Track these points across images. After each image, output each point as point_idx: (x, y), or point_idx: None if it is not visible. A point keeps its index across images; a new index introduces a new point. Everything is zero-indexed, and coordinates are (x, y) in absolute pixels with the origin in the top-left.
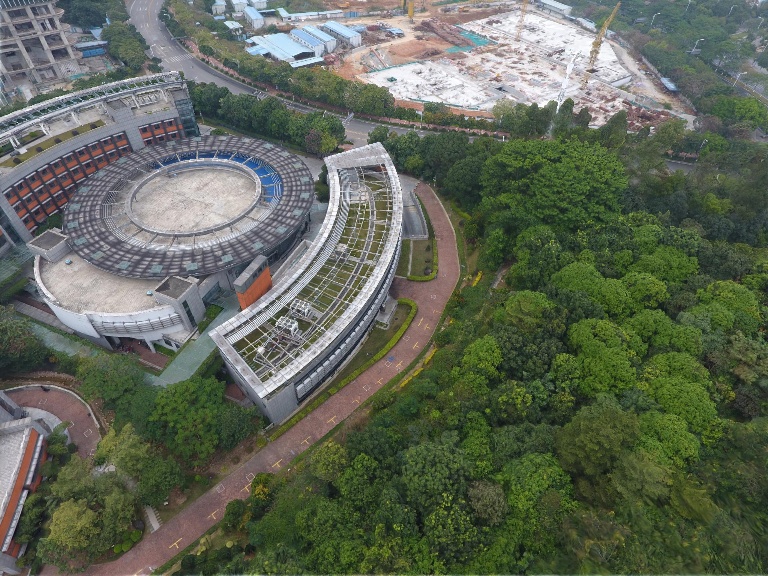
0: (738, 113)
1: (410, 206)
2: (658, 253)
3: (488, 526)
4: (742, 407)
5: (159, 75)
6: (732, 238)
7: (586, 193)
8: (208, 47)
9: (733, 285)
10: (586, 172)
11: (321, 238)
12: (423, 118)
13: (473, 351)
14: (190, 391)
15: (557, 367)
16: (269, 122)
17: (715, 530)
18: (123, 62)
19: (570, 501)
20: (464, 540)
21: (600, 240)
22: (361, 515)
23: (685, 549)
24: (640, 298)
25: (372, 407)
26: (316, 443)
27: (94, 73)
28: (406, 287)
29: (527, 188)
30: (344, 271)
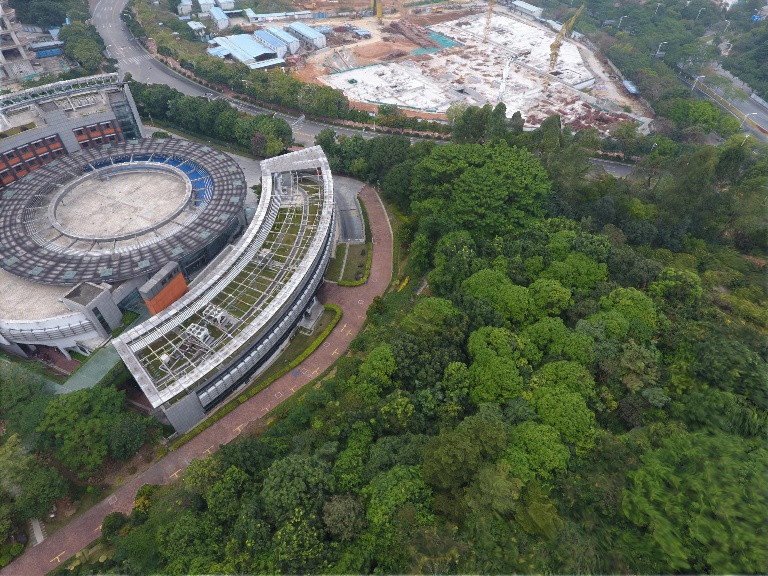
0: (692, 116)
1: (352, 210)
2: (569, 259)
3: (337, 542)
4: (627, 416)
5: (97, 77)
6: (658, 243)
7: (505, 198)
8: (166, 48)
9: (632, 292)
10: (507, 177)
11: (243, 243)
12: (376, 120)
13: (368, 360)
14: (82, 401)
15: (448, 376)
16: (216, 124)
17: (556, 545)
18: (79, 63)
19: (427, 515)
20: (307, 557)
21: (514, 246)
22: (225, 529)
23: (521, 565)
24: (543, 305)
25: (276, 416)
26: (215, 453)
27: (44, 74)
28: (335, 292)
29: (450, 193)
30: None
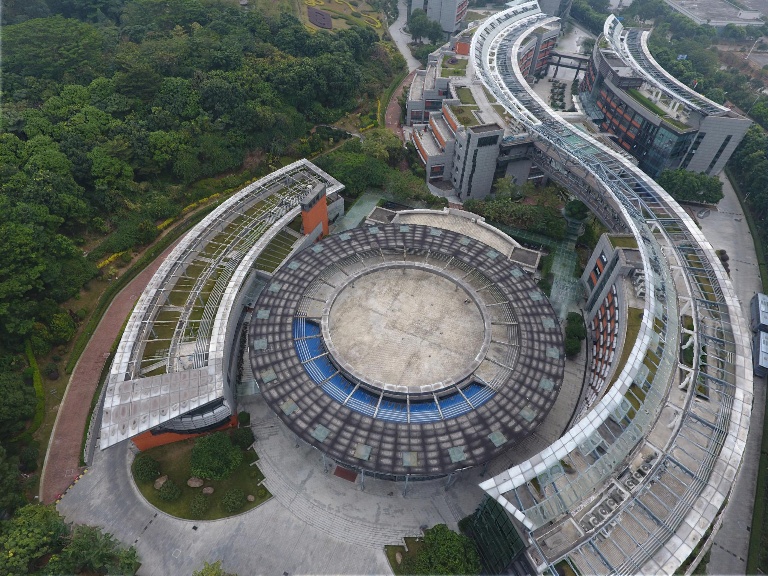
0: None
1: None
2: None
3: None
4: None
5: None
6: None
7: None
8: None
9: None
10: None
11: (252, 254)
12: None
13: None
14: (347, 161)
15: None
16: None
17: None
18: None
19: None
20: None
21: None
22: None
23: None
24: None
25: None
26: None
27: None
28: None
29: None
30: (237, 224)
